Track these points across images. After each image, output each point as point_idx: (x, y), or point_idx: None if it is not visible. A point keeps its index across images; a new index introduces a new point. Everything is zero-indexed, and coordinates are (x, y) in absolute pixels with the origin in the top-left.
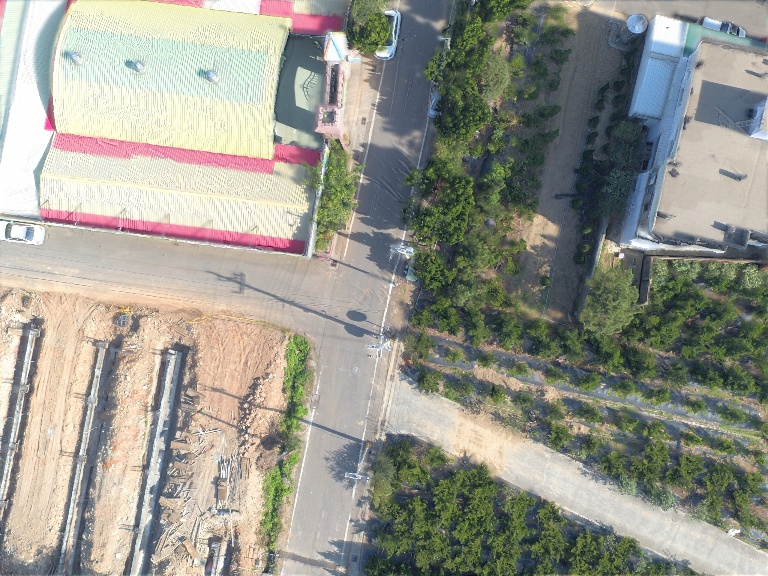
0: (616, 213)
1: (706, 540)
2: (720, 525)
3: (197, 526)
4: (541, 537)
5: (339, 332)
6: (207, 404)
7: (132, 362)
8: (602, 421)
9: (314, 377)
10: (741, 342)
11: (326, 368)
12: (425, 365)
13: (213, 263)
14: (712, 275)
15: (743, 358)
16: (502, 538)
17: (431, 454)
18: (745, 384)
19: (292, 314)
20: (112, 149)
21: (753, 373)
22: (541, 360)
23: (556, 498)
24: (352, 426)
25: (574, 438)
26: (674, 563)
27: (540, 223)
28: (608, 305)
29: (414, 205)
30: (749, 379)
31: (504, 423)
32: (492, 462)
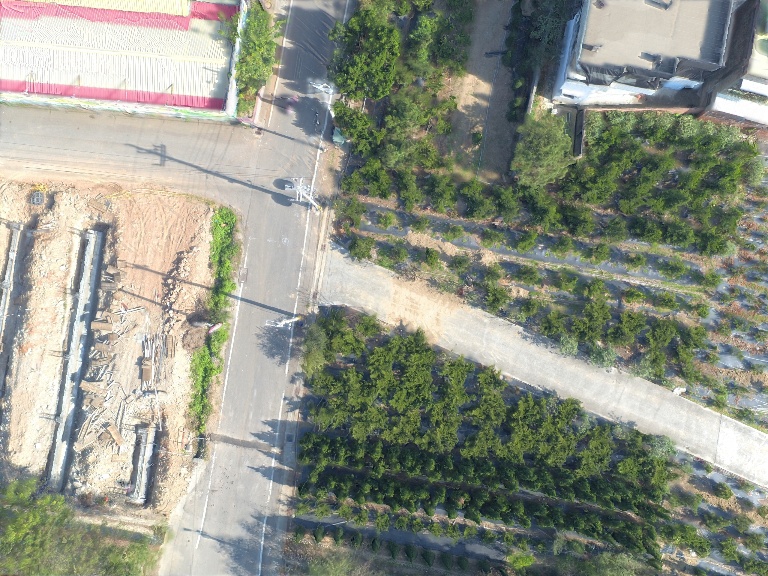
0: (545, 61)
1: (652, 400)
2: (665, 383)
3: (122, 411)
4: (482, 403)
5: (266, 202)
6: (129, 281)
7: (47, 240)
8: (541, 283)
9: (241, 250)
10: (678, 192)
11: (253, 240)
12: (357, 233)
13: (131, 135)
14: (646, 126)
15: (682, 213)
16: (442, 406)
17: (365, 321)
18: (684, 234)
19: (216, 185)
20: (19, 15)
21: (693, 228)
22: (477, 223)
23: (497, 364)
24: (283, 299)
25: (513, 302)
26: (620, 426)
27: (470, 82)
28: (539, 150)
29: (336, 57)
30: (688, 230)
31: (440, 288)
32: (429, 330)
